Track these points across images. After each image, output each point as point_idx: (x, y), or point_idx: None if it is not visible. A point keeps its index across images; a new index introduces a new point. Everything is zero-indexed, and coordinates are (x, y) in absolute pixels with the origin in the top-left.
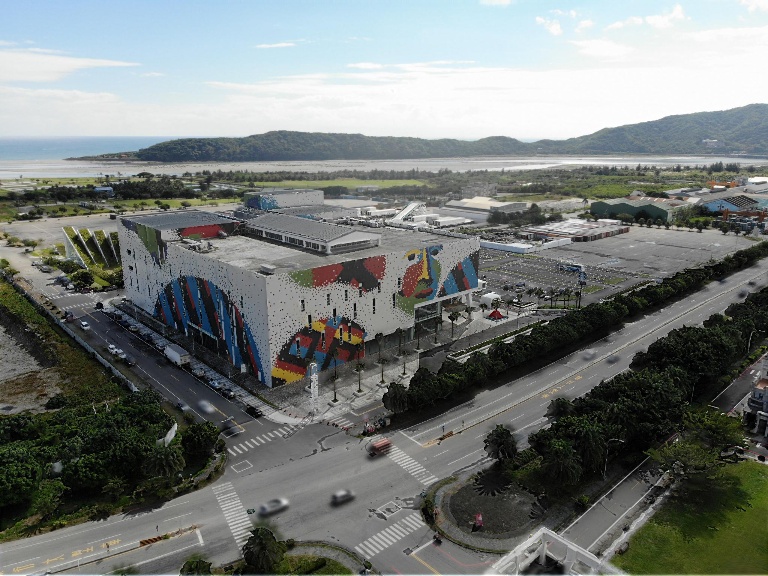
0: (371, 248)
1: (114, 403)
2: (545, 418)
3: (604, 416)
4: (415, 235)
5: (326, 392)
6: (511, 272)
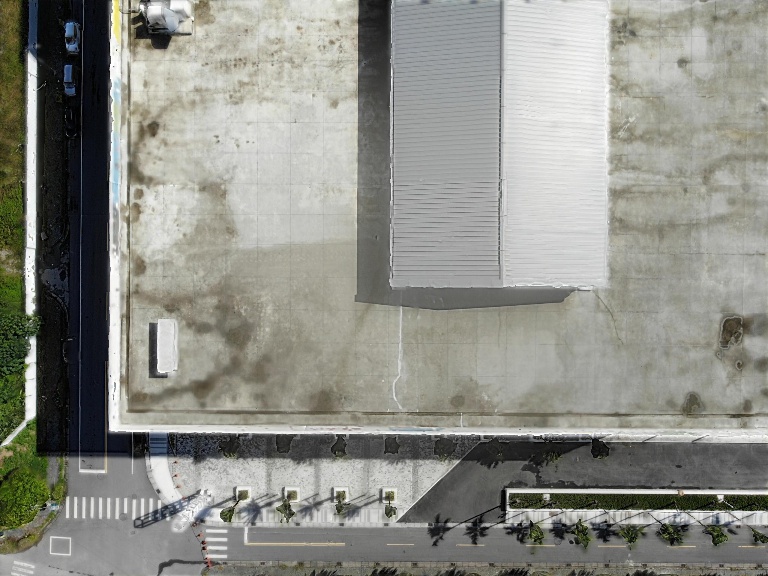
0: (532, 305)
1: (2, 264)
2: None
3: None
4: None
5: (255, 455)
6: None
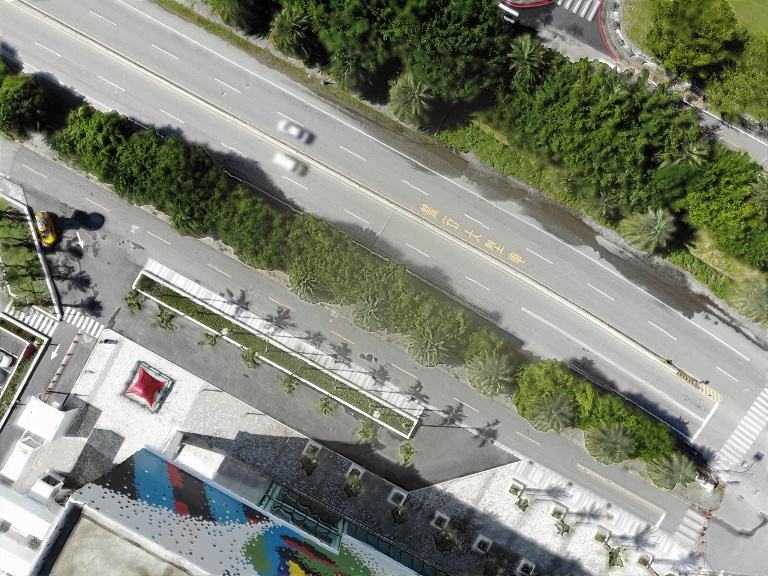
0: None
1: None
2: (590, 254)
3: (717, 170)
4: None
5: None
6: None
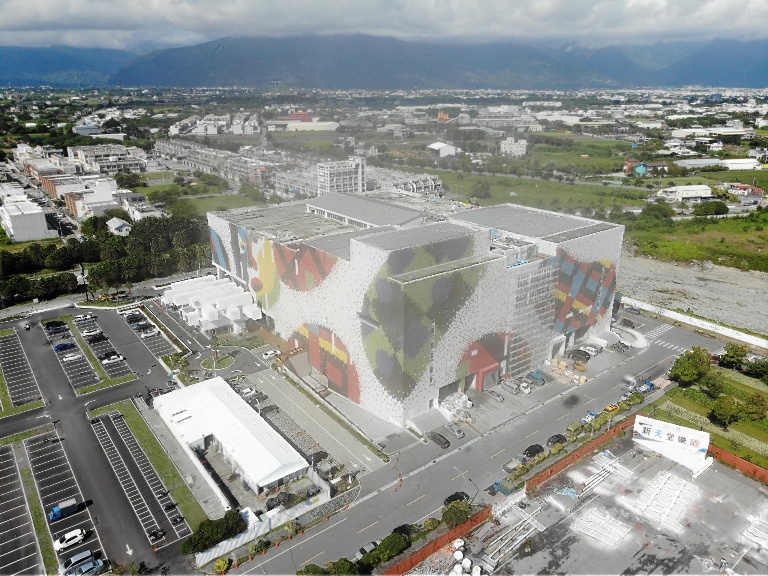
0: None
1: None
2: None
3: None
4: (260, 223)
5: None
6: (3, 389)
